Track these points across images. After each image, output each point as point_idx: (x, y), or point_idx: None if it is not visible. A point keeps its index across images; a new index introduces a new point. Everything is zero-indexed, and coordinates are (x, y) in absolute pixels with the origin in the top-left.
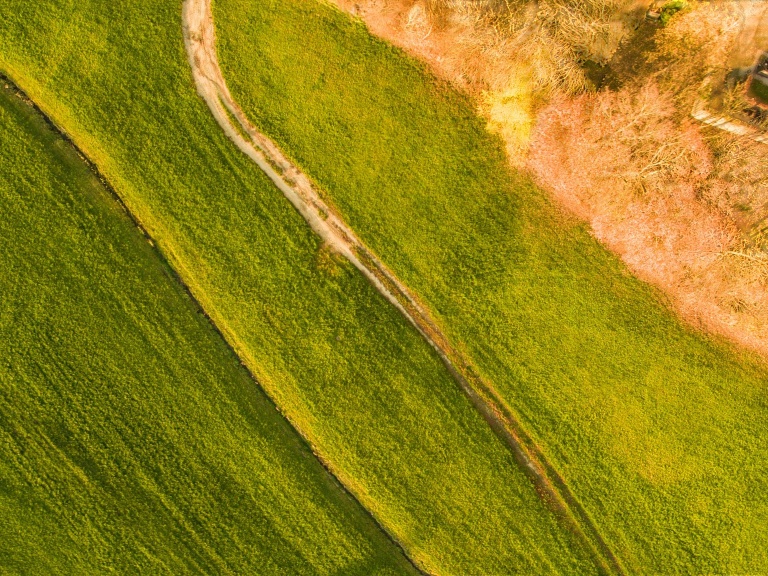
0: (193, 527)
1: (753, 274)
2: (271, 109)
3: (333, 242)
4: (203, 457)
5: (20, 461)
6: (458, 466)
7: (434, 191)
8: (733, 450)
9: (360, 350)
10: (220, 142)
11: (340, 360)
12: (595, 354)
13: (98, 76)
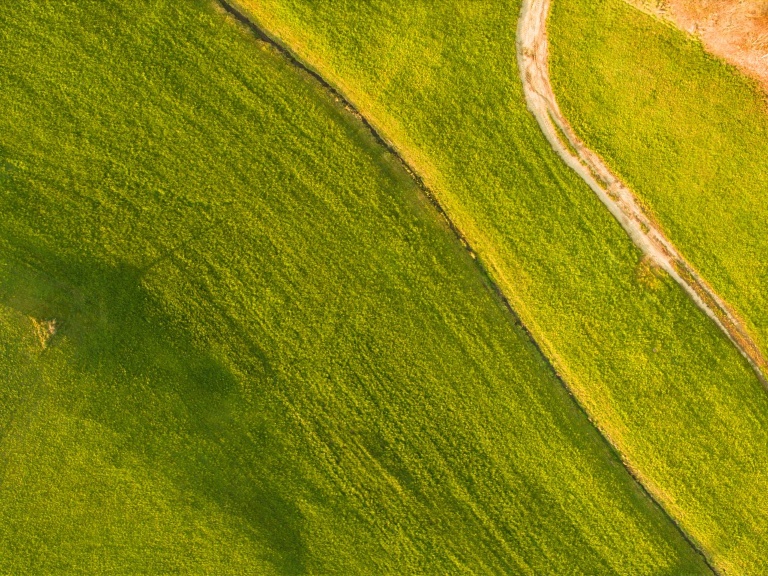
0: (503, 536)
1: None
2: (599, 124)
3: (653, 255)
4: (515, 467)
5: (335, 471)
6: (765, 476)
7: (757, 206)
8: None
9: (676, 362)
10: (547, 156)
11: (655, 371)
12: None
13: (430, 90)
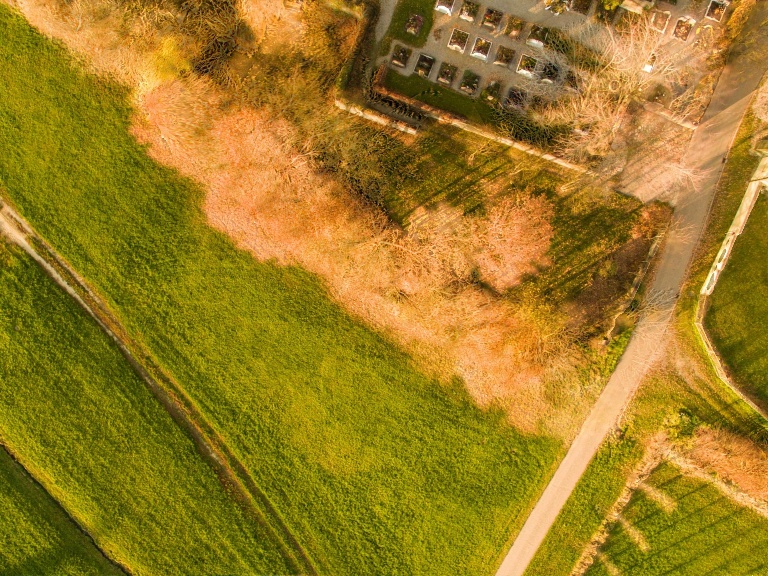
0: None
1: (407, 264)
2: None
3: (9, 232)
4: None
5: None
6: (141, 456)
7: (104, 182)
8: (409, 441)
9: (39, 340)
10: None
11: (20, 350)
12: (270, 345)
13: None
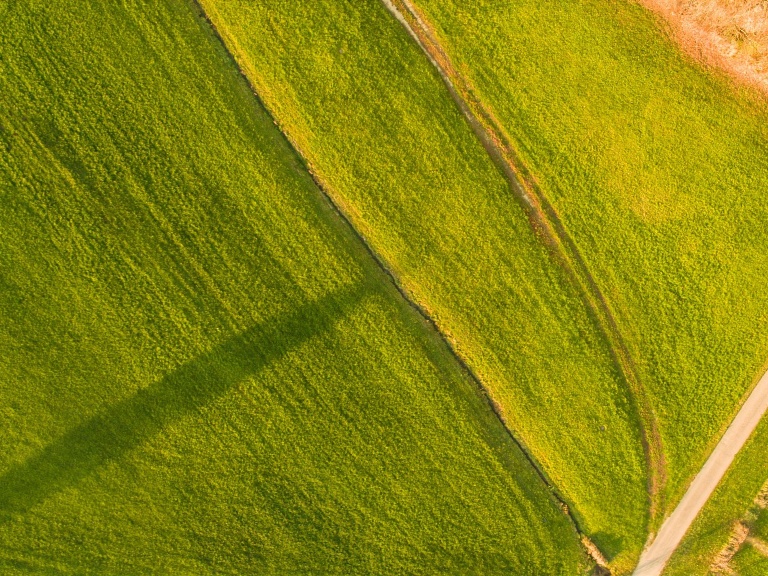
0: (181, 240)
1: None
2: None
3: None
4: (196, 168)
5: (5, 159)
6: (454, 193)
7: None
8: (725, 189)
9: (363, 65)
10: None
11: (342, 74)
12: (596, 83)
13: None
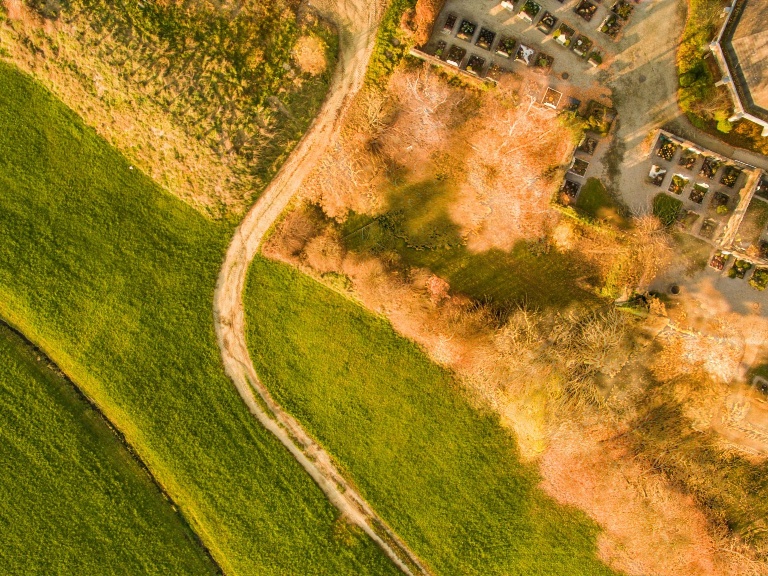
0: None
1: (741, 569)
2: (296, 390)
3: (350, 514)
4: None
5: None
6: None
7: (448, 472)
8: None
9: None
10: (245, 419)
11: None
12: None
13: (129, 354)
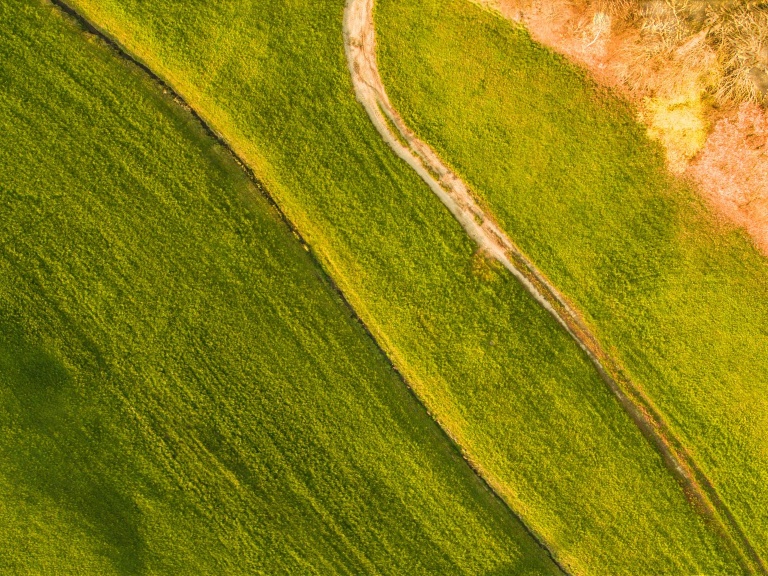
0: (343, 531)
1: None
2: (429, 115)
3: (488, 247)
4: (354, 461)
5: (172, 465)
6: (608, 470)
7: (591, 197)
8: None
9: (513, 354)
10: (378, 148)
11: (493, 364)
12: (747, 358)
13: (257, 82)
